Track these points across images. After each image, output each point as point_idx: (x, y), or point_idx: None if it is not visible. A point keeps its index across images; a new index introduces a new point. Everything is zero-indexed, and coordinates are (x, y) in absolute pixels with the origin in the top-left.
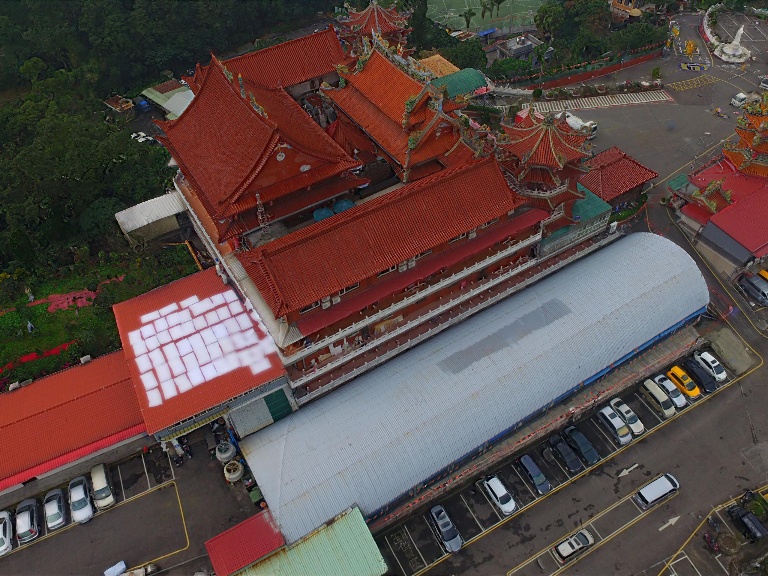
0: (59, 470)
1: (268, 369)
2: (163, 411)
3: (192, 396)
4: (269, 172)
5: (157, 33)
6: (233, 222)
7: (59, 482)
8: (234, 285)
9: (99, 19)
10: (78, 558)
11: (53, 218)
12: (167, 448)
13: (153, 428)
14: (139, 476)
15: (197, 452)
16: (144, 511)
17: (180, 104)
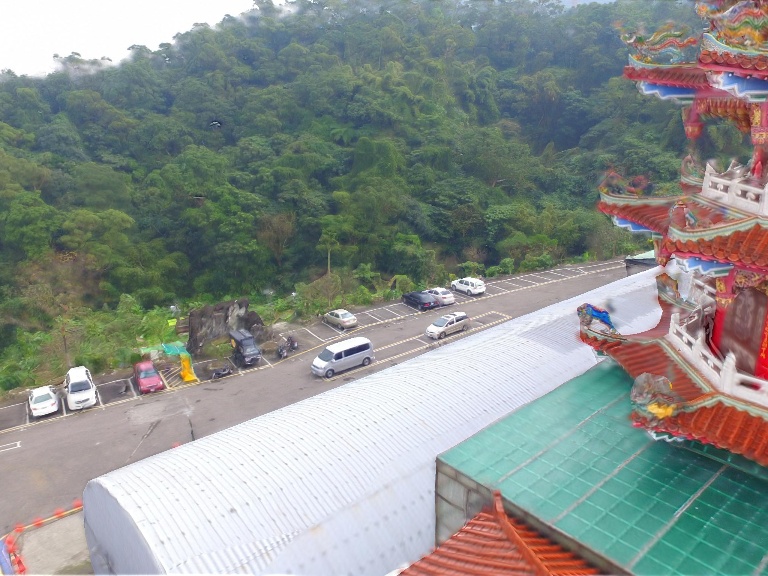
0: None
1: None
2: None
3: None
4: None
5: None
6: None
7: None
8: None
9: None
10: None
11: None
12: None
13: None
14: None
15: None
16: None
17: None
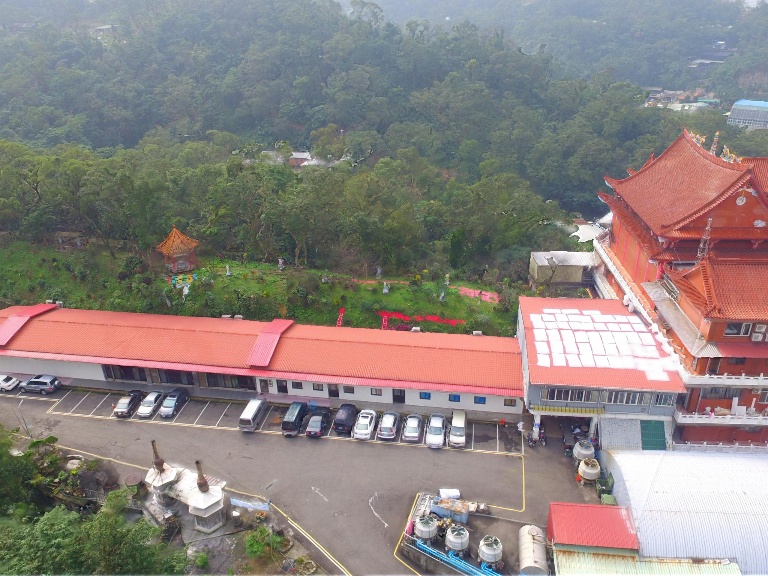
0: (424, 404)
1: (665, 381)
2: (549, 372)
3: (580, 372)
4: (722, 213)
5: (584, 179)
6: (666, 250)
7: (421, 413)
8: (640, 314)
9: (540, 160)
10: (419, 470)
11: (480, 243)
12: (523, 429)
13: (537, 380)
14: (490, 438)
15: (551, 444)
16: (488, 464)
17: (584, 233)
